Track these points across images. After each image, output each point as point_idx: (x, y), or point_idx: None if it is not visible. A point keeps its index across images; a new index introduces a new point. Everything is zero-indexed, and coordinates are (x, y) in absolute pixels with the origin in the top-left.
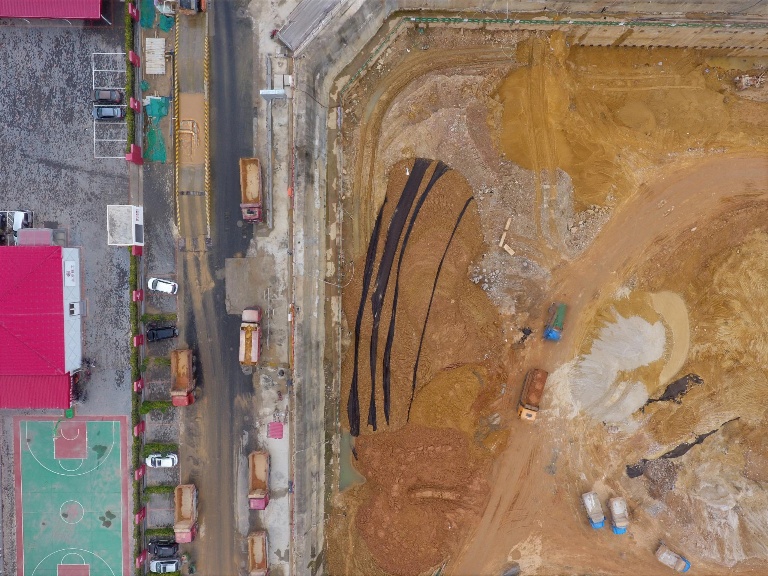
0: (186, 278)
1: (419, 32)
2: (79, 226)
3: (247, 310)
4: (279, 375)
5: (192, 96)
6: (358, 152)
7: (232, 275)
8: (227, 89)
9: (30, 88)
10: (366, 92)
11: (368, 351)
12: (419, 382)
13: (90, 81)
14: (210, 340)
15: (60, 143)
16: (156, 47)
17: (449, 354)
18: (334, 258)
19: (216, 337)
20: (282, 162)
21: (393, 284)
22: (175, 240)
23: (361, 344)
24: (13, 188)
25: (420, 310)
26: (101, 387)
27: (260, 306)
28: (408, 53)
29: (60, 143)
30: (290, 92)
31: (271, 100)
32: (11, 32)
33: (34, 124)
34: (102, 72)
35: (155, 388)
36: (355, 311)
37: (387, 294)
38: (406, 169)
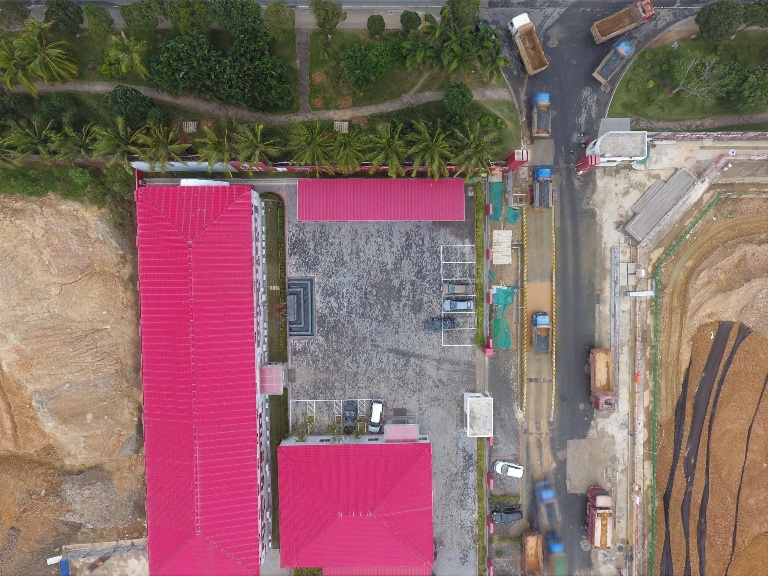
0: (528, 459)
1: (727, 202)
2: (427, 412)
3: (601, 496)
4: (618, 551)
5: (539, 286)
6: (667, 319)
7: (573, 456)
8: (571, 277)
9: (381, 281)
10: (673, 259)
11: (679, 513)
12: (739, 547)
13: (439, 273)
14: (551, 518)
15: (409, 333)
16: (503, 239)
17: (767, 520)
18: (647, 424)
19: (557, 515)
20: (624, 347)
21: (704, 448)
22: (518, 423)
23: (670, 505)
24: (363, 377)
25: (734, 474)
26: (446, 566)
27: (600, 485)
28: (714, 221)
29: (409, 333)
30: (634, 280)
31: (614, 287)
32: (363, 227)
33: (384, 315)
34: (450, 264)
35: (497, 565)
36: (666, 474)
37: (699, 458)
38: (711, 333)
